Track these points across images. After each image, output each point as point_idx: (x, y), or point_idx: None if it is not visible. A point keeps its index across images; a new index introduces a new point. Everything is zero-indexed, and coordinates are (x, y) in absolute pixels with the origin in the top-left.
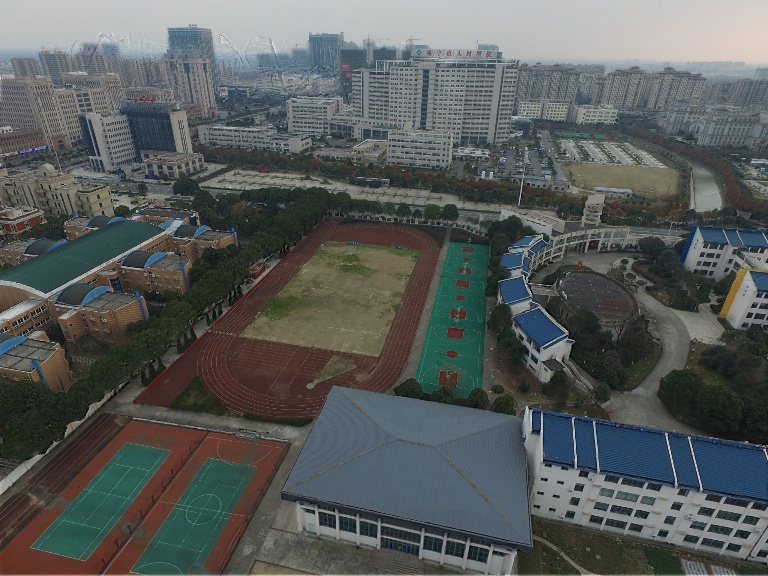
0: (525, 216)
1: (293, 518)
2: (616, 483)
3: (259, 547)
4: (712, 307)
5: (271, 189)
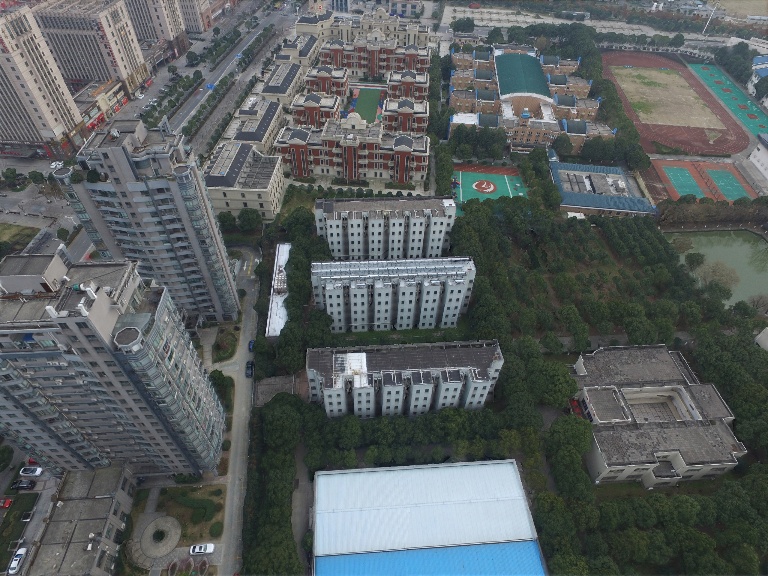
0: (752, 42)
1: (766, 184)
2: None
3: (764, 192)
4: None
5: (544, 25)
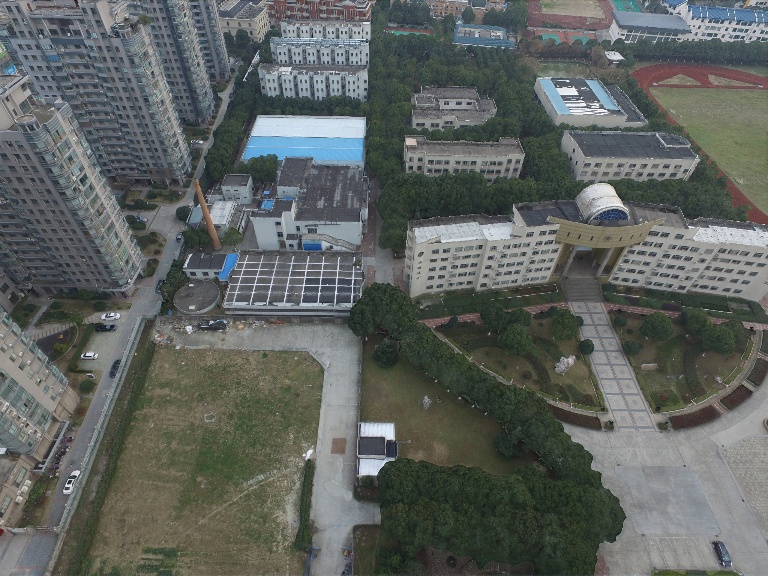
0: None
1: None
2: (711, 23)
3: None
4: (740, 6)
5: None
